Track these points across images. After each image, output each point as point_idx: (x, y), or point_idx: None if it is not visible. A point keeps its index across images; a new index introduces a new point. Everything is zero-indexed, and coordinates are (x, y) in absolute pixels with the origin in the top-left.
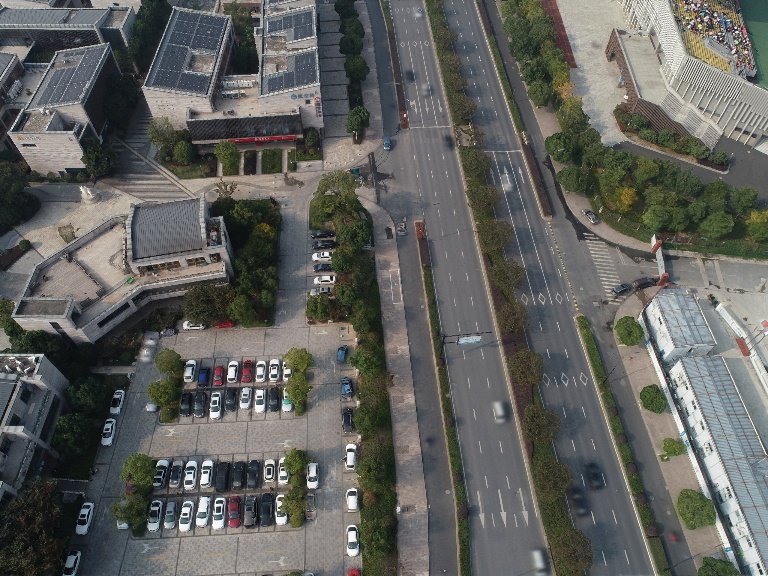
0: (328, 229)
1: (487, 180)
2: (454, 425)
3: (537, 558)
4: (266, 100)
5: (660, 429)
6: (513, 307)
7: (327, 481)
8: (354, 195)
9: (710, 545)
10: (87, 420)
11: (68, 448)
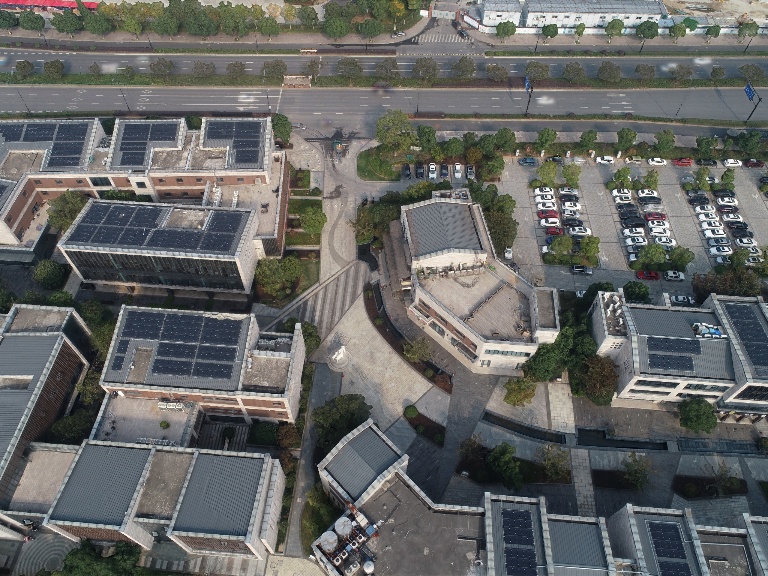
0: None
1: None
2: None
3: (645, 94)
4: None
5: (560, 40)
6: (491, 70)
7: None
8: None
9: (622, 38)
10: None
11: None
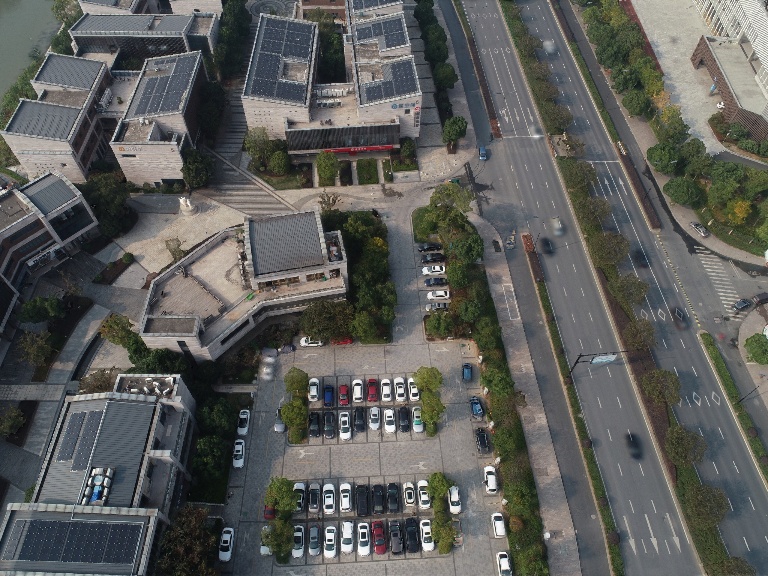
0: (434, 242)
1: (589, 191)
2: (591, 446)
3: None
4: (366, 110)
5: None
6: (639, 324)
7: (469, 505)
8: (469, 208)
9: None
10: (225, 443)
11: (207, 472)
